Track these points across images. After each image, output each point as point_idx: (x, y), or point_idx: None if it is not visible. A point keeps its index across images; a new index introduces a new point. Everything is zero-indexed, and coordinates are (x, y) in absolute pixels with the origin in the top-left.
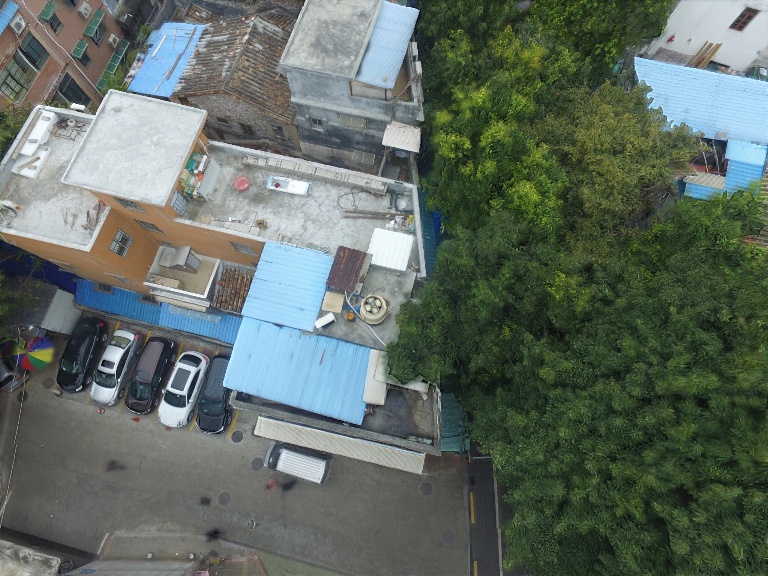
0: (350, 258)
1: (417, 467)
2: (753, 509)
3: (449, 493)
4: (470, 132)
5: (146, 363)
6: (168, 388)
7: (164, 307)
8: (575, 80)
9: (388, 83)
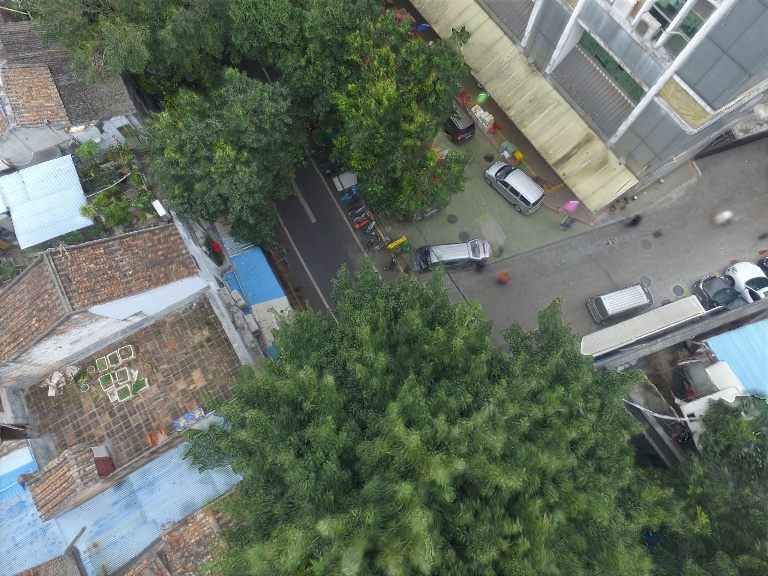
0: None
1: None
2: (494, 460)
3: None
4: None
5: None
6: None
7: None
8: None
9: None
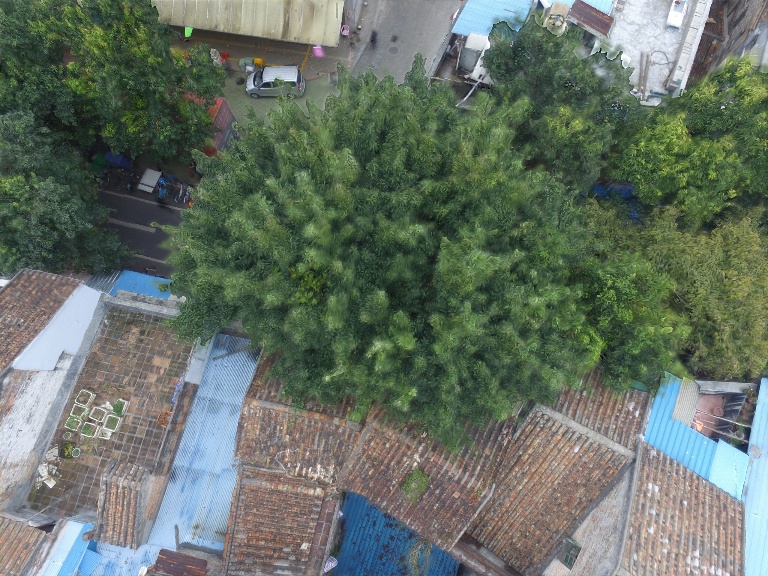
0: (602, 21)
1: None
2: None
3: None
4: None
5: None
6: None
7: None
8: None
9: None
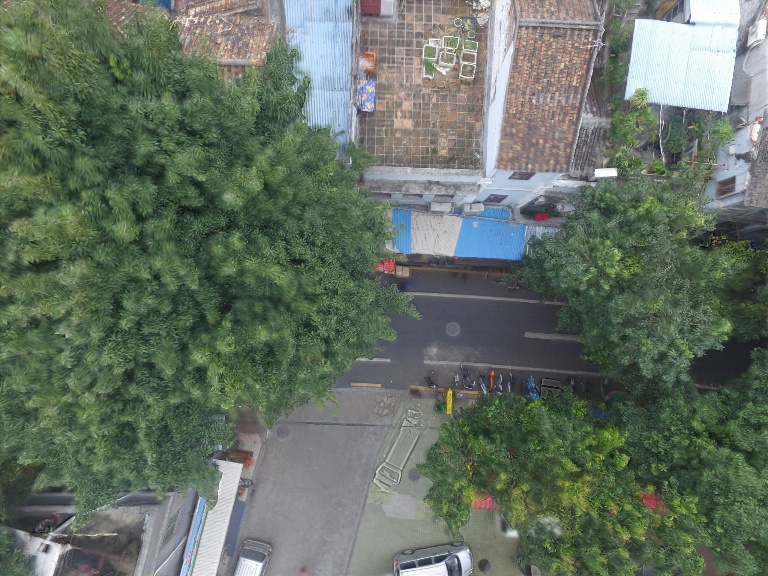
0: None
1: (234, 470)
2: None
3: None
4: None
5: None
6: None
7: None
8: None
9: None
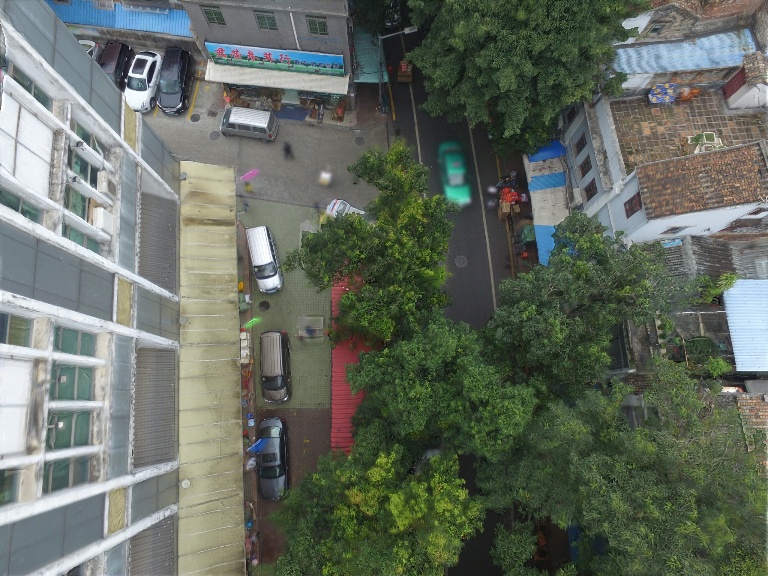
0: None
1: (343, 88)
2: None
3: (379, 143)
4: None
5: (108, 58)
6: (129, 74)
7: (118, 11)
8: None
9: None
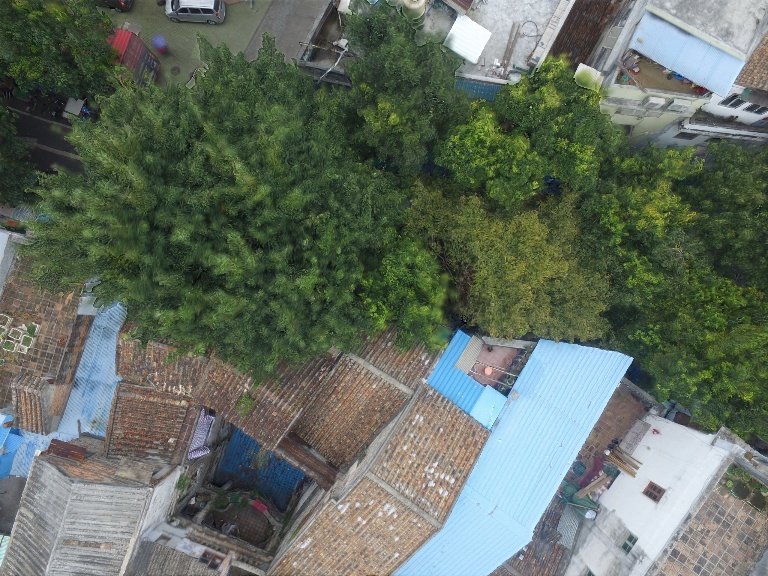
0: None
1: None
2: None
3: None
4: (554, 86)
5: None
6: None
7: None
8: (620, 291)
9: (635, 43)
